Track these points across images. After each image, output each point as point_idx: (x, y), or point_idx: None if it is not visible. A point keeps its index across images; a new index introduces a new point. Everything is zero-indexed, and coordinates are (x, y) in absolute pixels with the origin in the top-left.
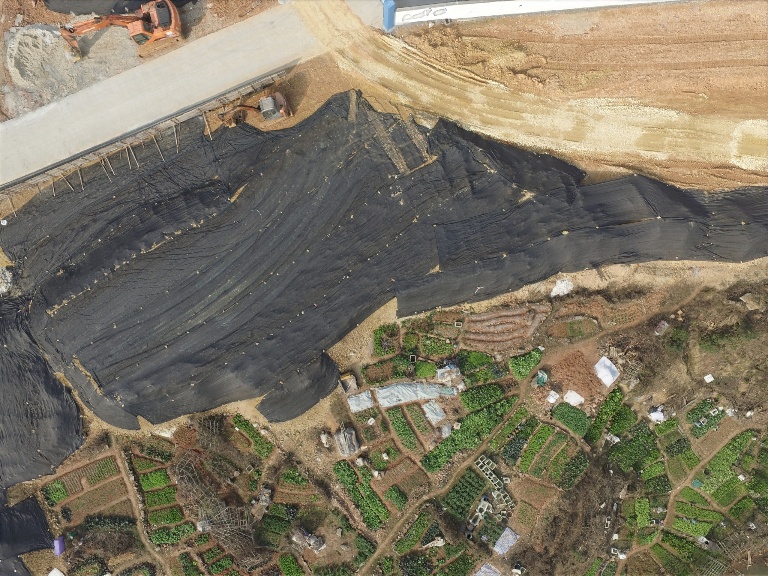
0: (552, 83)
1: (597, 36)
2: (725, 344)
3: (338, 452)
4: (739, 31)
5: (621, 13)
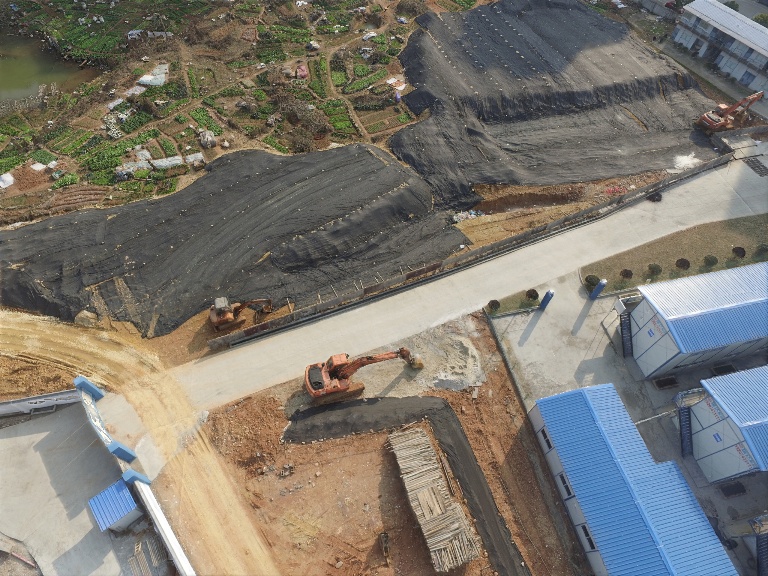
0: None
1: None
2: None
3: None
4: None
5: None
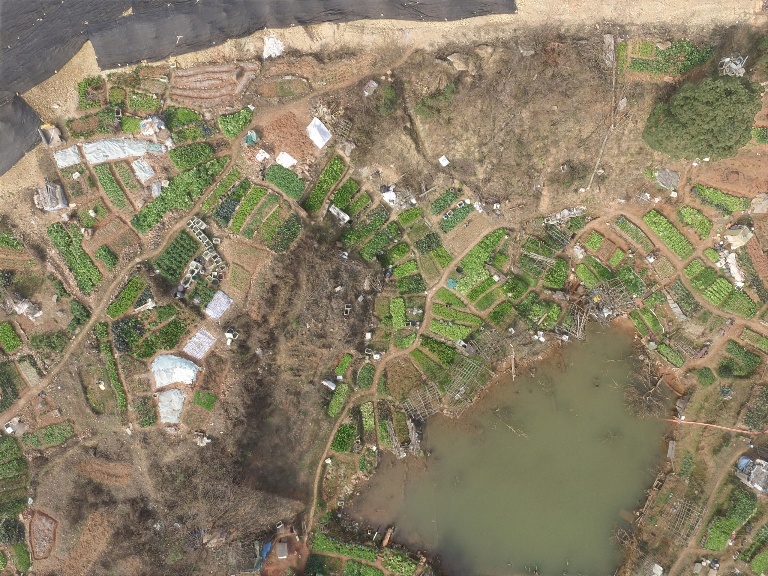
0: None
1: None
2: (440, 110)
3: (51, 214)
4: None
5: None
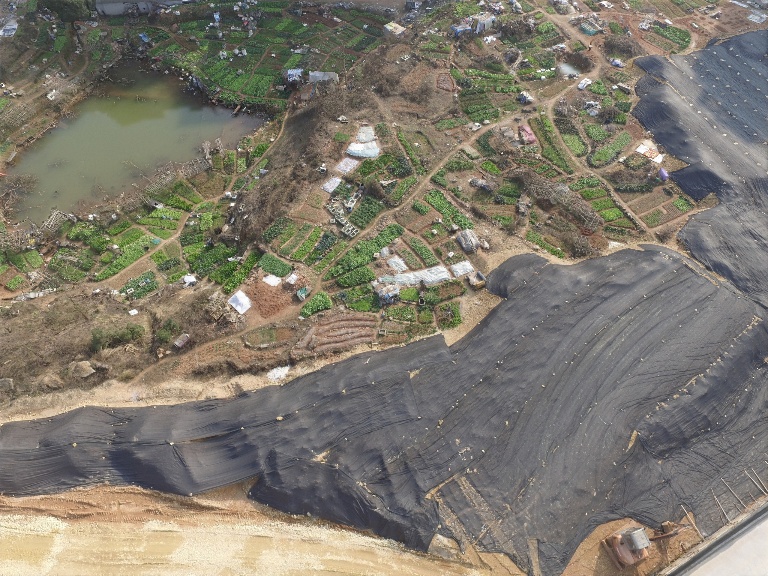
0: None
1: None
2: None
3: None
4: None
5: None
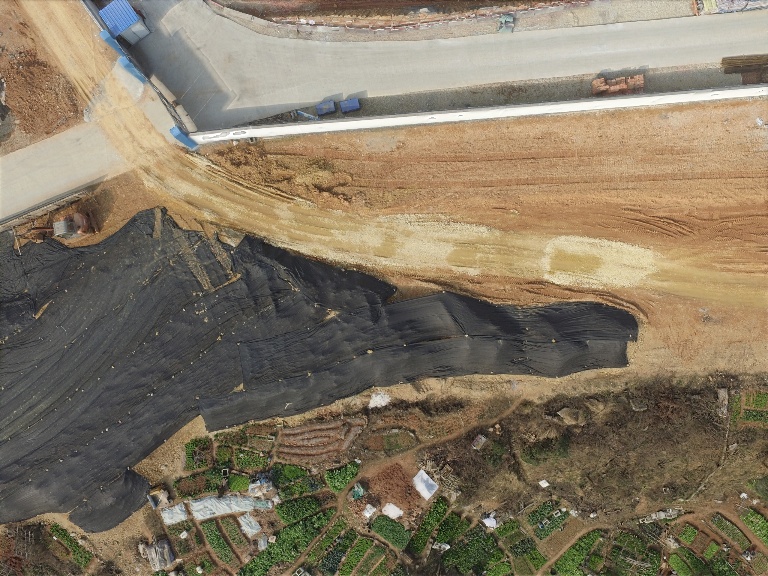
0: (358, 200)
1: (404, 154)
2: None
3: None
4: (548, 148)
5: (428, 131)
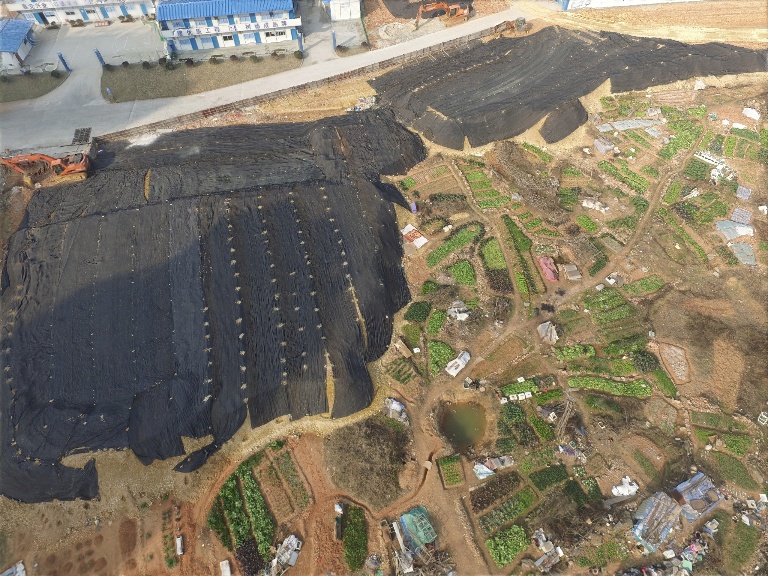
0: (650, 21)
1: (663, 10)
2: None
3: (598, 157)
4: (729, 7)
5: (670, 5)
